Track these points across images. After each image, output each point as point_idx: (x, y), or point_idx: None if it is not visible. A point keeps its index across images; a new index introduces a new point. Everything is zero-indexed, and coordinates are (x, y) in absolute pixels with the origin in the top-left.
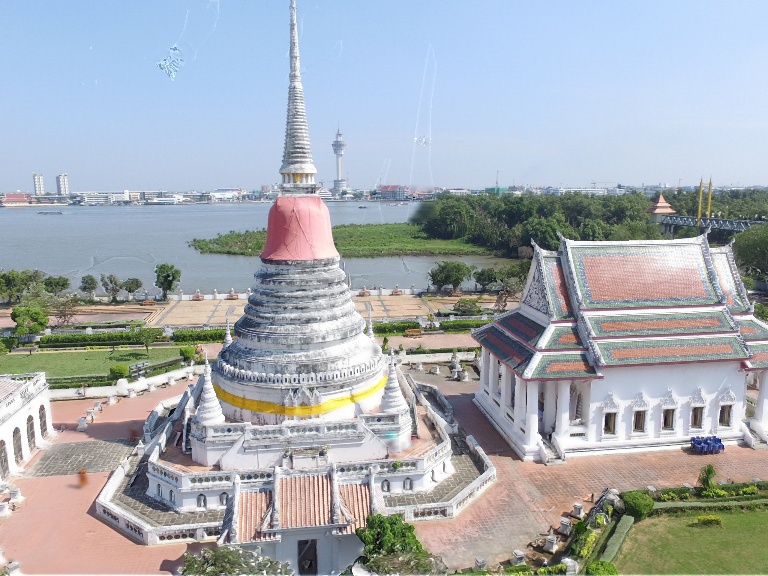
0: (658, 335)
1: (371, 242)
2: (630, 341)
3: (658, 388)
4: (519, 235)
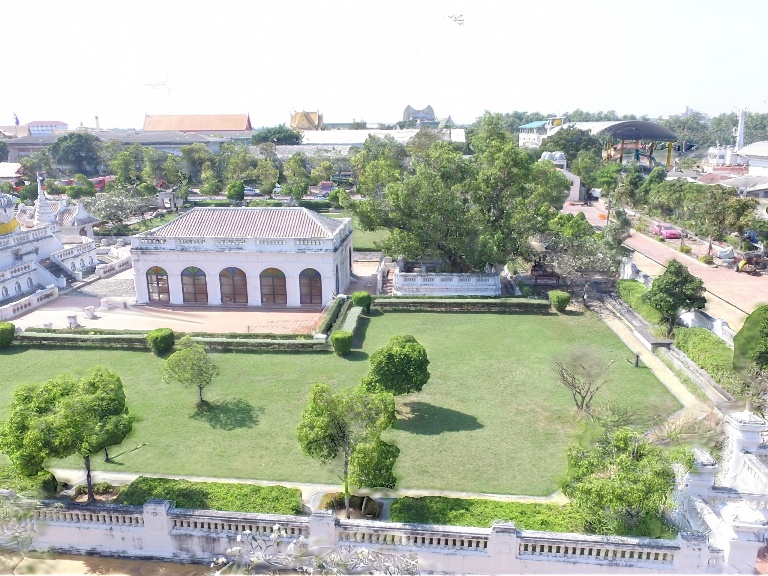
0: None
1: None
2: None
3: None
4: None
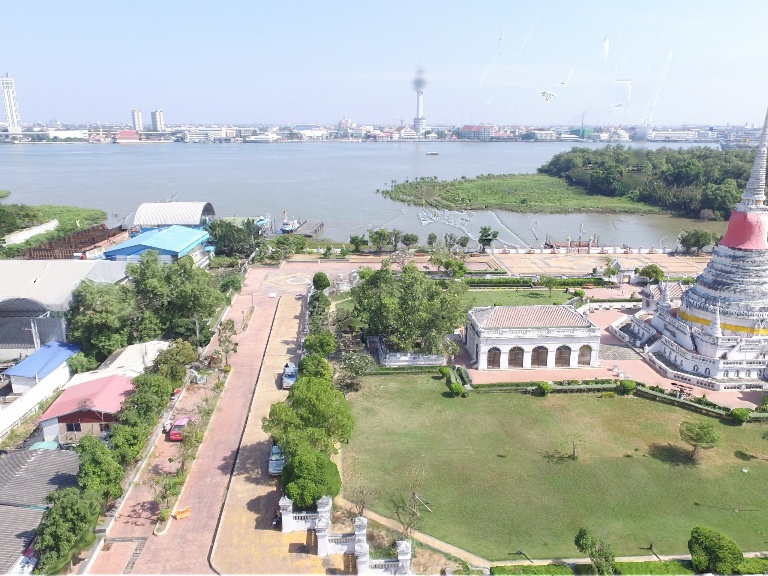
0: None
1: (574, 202)
2: None
3: None
4: (699, 199)
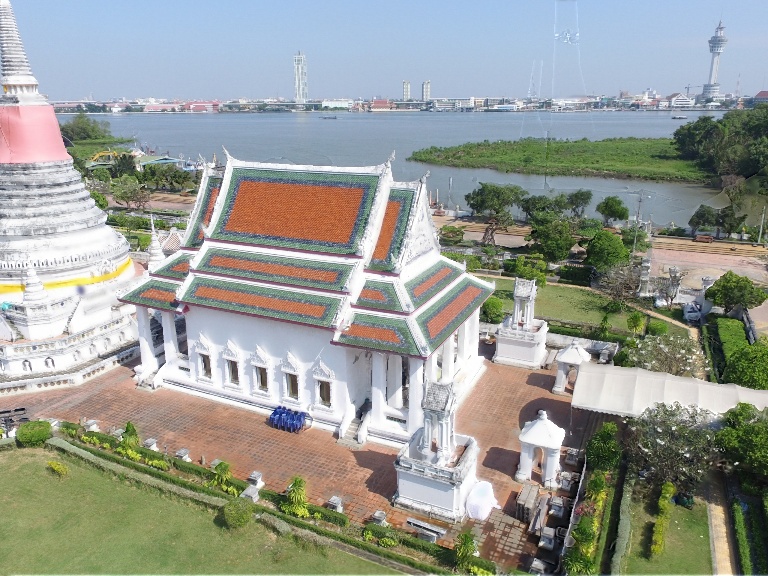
0: (256, 280)
1: (537, 158)
2: (227, 281)
3: (249, 340)
4: (735, 159)
